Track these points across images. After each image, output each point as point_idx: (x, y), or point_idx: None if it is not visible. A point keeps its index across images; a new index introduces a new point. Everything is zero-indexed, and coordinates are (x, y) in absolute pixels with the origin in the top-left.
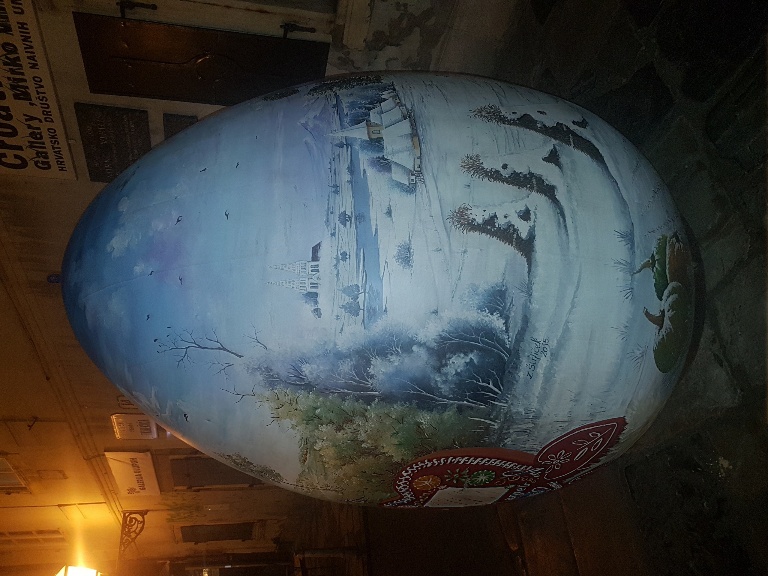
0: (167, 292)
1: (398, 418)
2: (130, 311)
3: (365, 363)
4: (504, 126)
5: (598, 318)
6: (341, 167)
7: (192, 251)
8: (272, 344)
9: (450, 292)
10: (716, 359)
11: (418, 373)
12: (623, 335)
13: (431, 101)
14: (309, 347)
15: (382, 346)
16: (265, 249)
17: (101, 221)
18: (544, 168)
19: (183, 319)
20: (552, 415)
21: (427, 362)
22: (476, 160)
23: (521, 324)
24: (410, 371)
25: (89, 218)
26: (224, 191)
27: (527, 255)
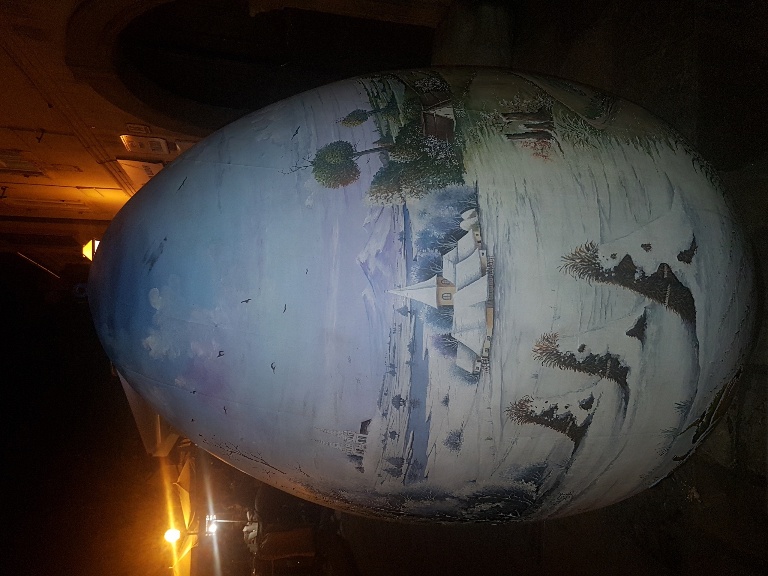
0: (211, 411)
1: (422, 521)
2: (173, 405)
3: (400, 501)
4: (596, 285)
5: (627, 473)
6: (401, 343)
7: (236, 390)
8: (315, 476)
9: (492, 469)
10: (728, 423)
11: (447, 509)
12: (645, 477)
13: (518, 239)
14: (349, 485)
15: (418, 495)
16: (313, 413)
17: (131, 300)
18: (624, 345)
19: (228, 436)
20: (558, 517)
21: (457, 505)
22: (552, 342)
23: (552, 486)
24: (440, 508)
25: (114, 274)
26: (270, 338)
27: (577, 439)
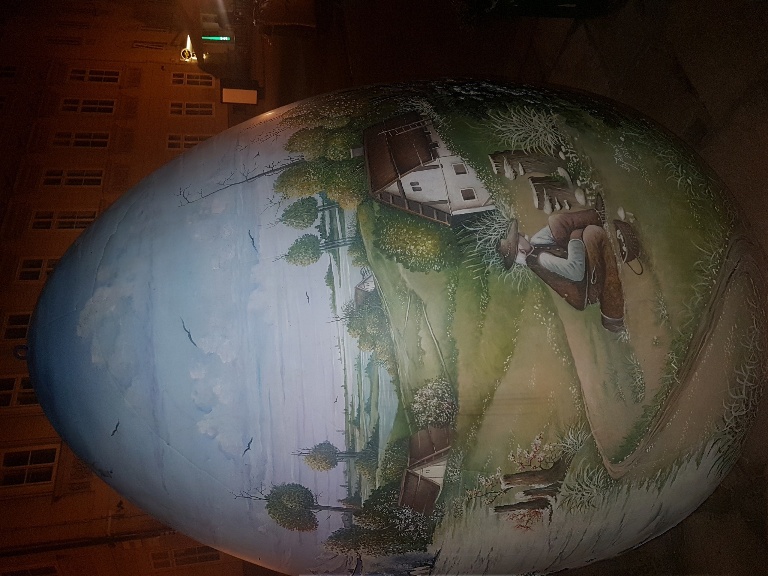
0: None
1: None
2: None
3: None
4: None
5: None
6: None
7: None
8: None
9: None
10: None
11: None
12: None
13: None
14: None
15: None
16: None
17: None
18: None
19: None
20: None
21: None
22: None
23: None
24: None
25: None
26: None
27: None
